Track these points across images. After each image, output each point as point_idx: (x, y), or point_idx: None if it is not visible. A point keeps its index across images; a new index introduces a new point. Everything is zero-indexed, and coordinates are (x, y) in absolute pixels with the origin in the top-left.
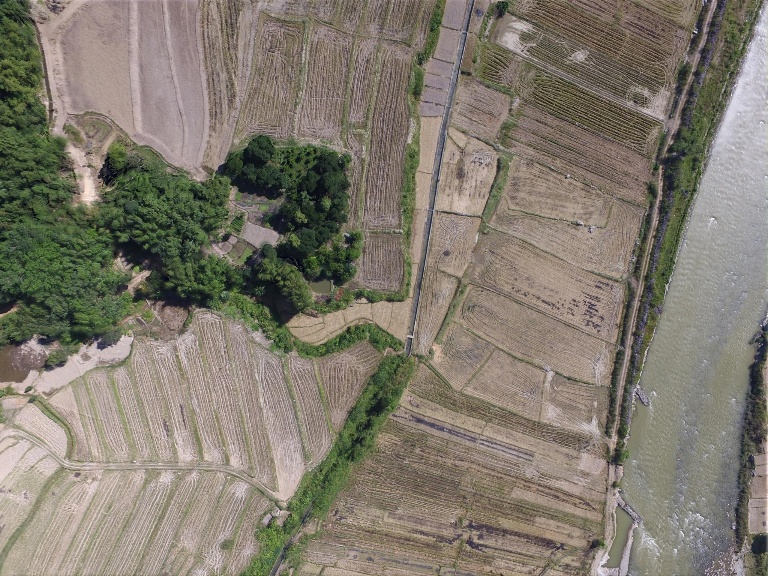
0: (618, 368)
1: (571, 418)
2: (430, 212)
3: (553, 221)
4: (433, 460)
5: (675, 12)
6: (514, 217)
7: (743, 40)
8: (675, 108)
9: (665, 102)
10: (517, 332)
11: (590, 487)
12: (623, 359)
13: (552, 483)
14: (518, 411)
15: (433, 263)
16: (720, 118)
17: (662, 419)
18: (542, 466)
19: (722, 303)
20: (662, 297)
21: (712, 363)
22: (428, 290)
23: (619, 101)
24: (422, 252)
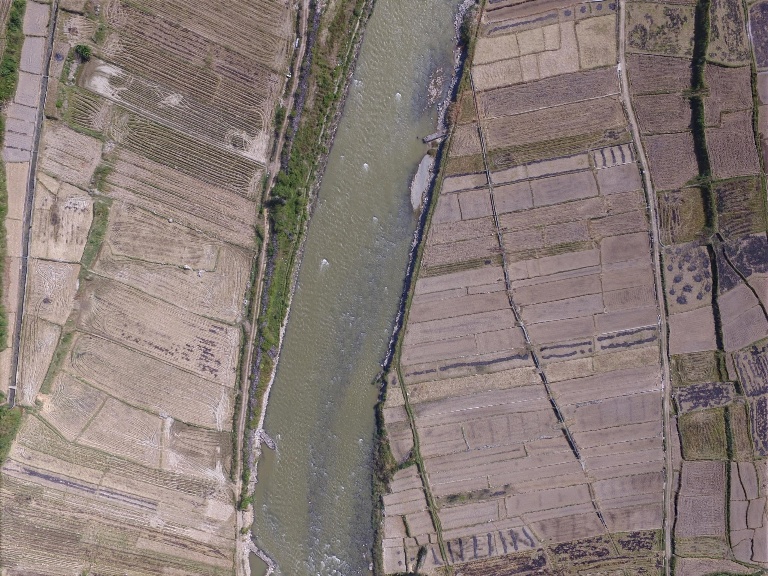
0: (236, 413)
1: (194, 465)
2: (25, 259)
3: (160, 266)
4: (51, 513)
5: (266, 56)
6: (119, 262)
7: (337, 84)
8: (274, 151)
9: (265, 145)
10: (131, 379)
11: (219, 534)
12: (241, 403)
13: (179, 532)
14: (137, 460)
15: (33, 311)
16: (323, 160)
17: (289, 462)
18: (167, 515)
19: (341, 344)
20: (276, 340)
21: (336, 404)
22: (30, 339)
23: (218, 144)
24: (19, 300)
